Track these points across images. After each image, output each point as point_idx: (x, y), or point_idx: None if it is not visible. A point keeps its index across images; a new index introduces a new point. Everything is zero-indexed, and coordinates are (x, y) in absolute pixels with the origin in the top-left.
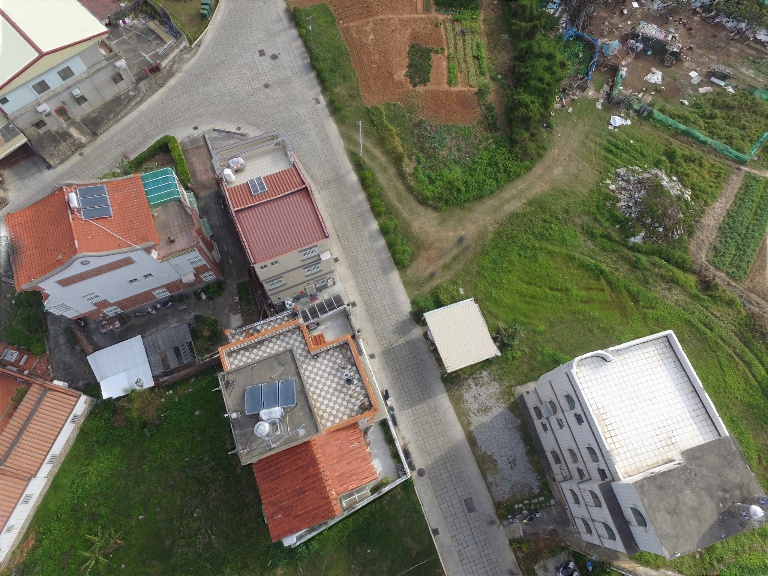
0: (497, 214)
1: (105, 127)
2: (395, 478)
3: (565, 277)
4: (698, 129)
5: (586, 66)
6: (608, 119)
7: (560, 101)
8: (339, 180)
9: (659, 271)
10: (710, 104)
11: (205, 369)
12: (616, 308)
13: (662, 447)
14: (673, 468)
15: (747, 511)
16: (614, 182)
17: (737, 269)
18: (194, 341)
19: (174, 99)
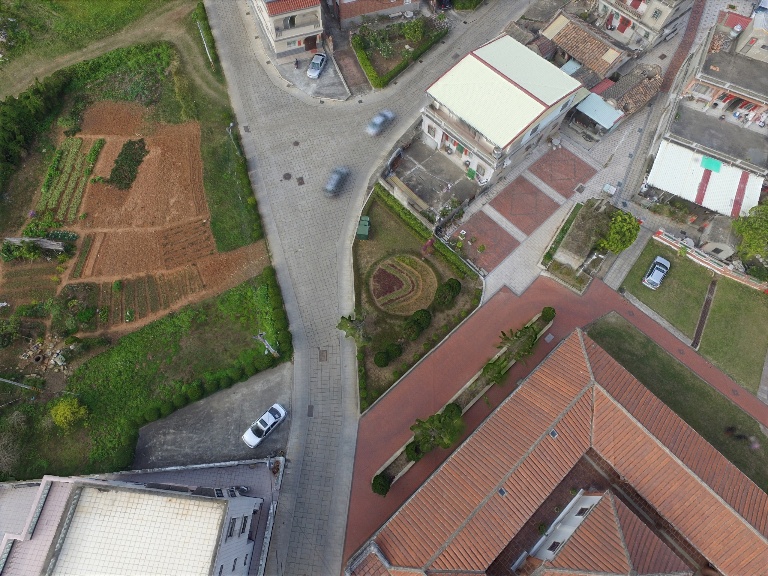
0: (113, 40)
1: None
2: None
3: (82, 4)
4: None
5: None
6: None
7: None
8: (237, 62)
9: (7, 1)
10: None
11: None
12: None
13: None
14: None
15: None
16: None
17: None
18: None
19: (384, 129)
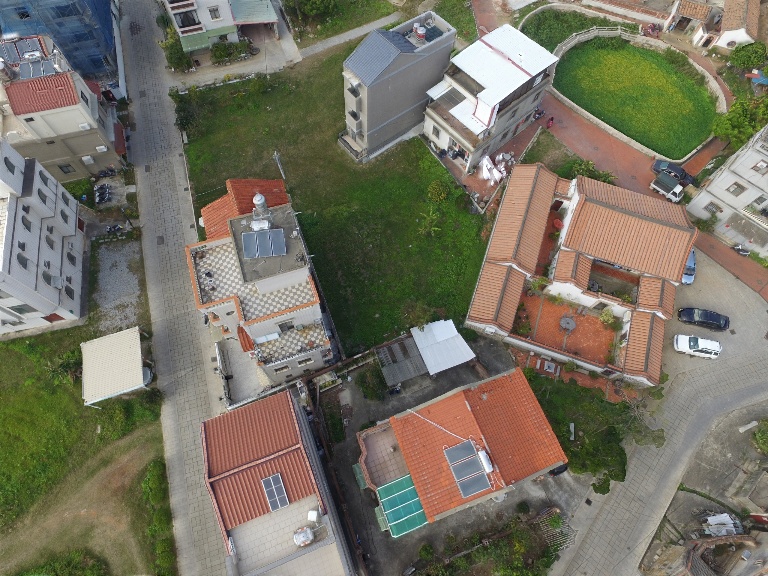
0: (8, 545)
1: None
2: None
3: None
4: None
5: None
6: None
7: None
8: None
9: None
10: None
11: None
12: None
13: None
14: None
15: None
16: None
17: None
18: None
19: None
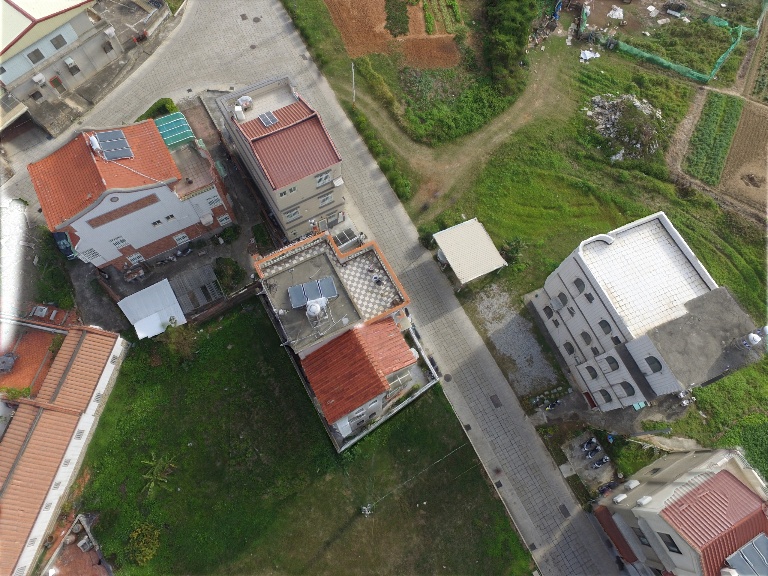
0: (487, 146)
1: (100, 96)
2: (424, 385)
3: (557, 196)
4: (661, 56)
5: (553, 7)
6: (579, 54)
7: (533, 41)
8: (335, 127)
9: (641, 183)
10: (669, 33)
11: (231, 307)
12: (606, 219)
13: (666, 310)
14: (679, 317)
15: (747, 339)
16: (591, 109)
17: (710, 175)
18: (218, 281)
19: (164, 65)
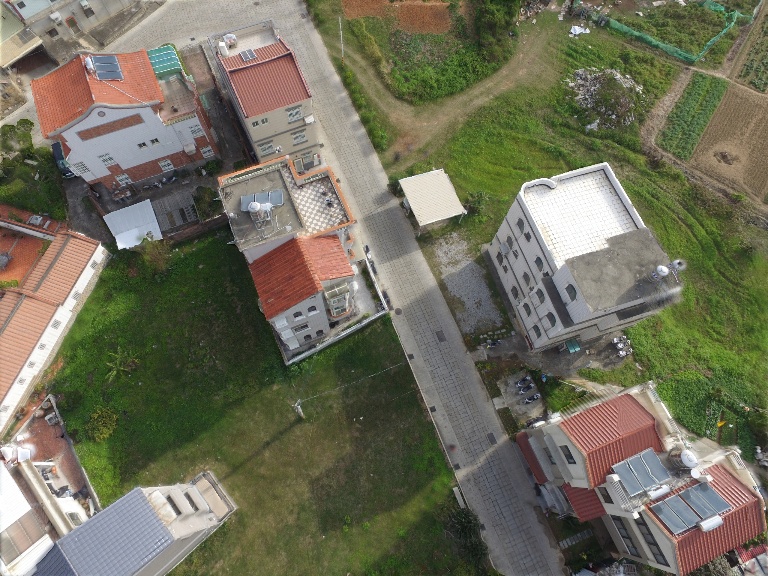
0: (467, 108)
1: (111, 39)
2: None
3: (528, 158)
4: (651, 35)
5: None
6: (569, 29)
7: (525, 14)
8: (323, 81)
9: (612, 152)
10: (663, 14)
11: (207, 232)
12: None
13: None
14: (599, 250)
15: (655, 270)
16: (573, 81)
17: (683, 150)
18: (196, 207)
19: (172, 15)
